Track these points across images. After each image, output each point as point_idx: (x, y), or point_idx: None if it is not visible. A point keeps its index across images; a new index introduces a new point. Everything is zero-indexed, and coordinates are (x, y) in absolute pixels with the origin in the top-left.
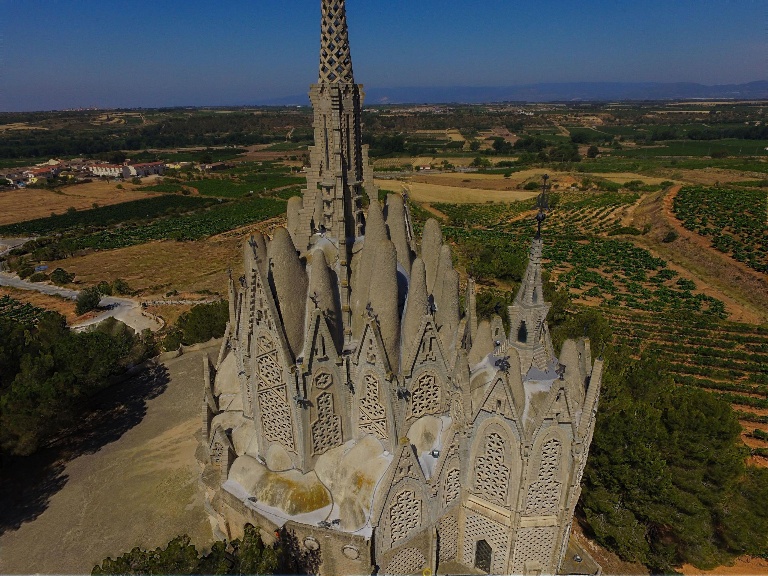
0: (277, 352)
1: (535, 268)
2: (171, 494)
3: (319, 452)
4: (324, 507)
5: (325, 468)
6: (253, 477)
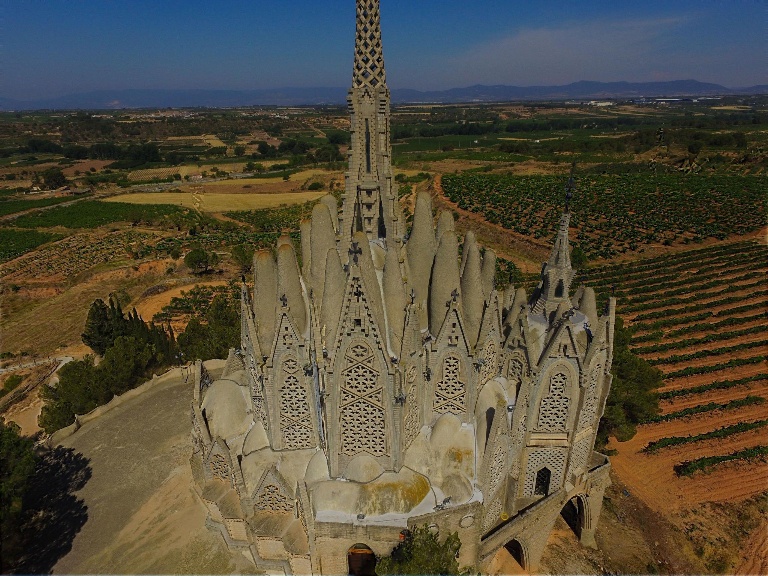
0: (374, 358)
1: (565, 236)
2: (201, 573)
3: (407, 446)
4: (427, 494)
5: (419, 458)
6: (350, 496)
